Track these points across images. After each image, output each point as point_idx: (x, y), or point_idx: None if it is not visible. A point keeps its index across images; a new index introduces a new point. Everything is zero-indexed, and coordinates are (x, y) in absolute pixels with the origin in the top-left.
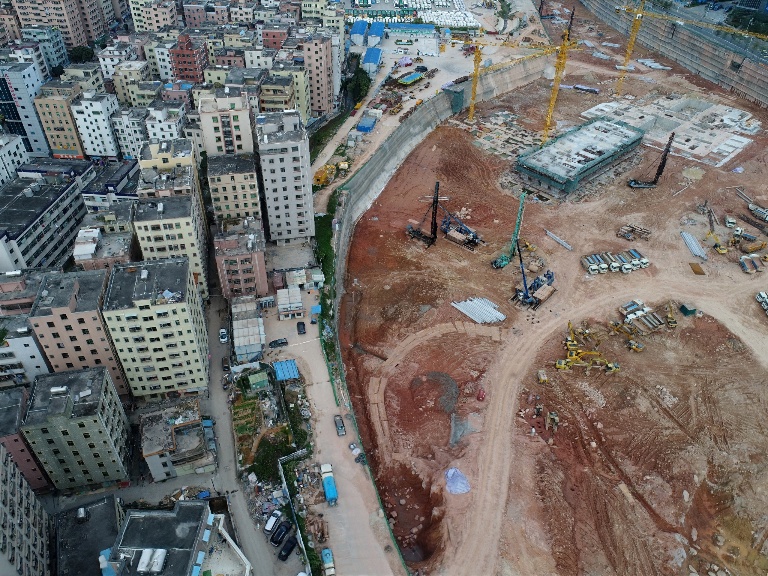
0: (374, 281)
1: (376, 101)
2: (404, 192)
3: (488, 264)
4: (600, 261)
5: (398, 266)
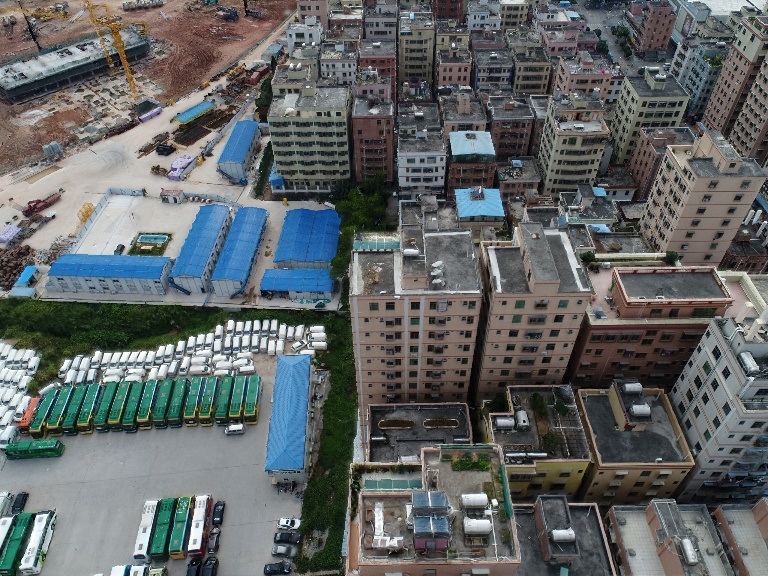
0: (289, 1)
1: (257, 73)
2: (255, 42)
3: (219, 6)
4: (152, 1)
5: (273, 6)
